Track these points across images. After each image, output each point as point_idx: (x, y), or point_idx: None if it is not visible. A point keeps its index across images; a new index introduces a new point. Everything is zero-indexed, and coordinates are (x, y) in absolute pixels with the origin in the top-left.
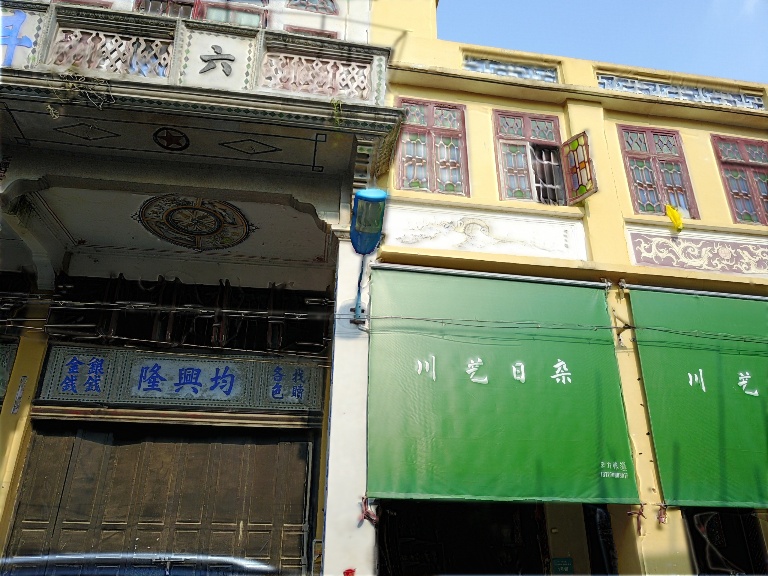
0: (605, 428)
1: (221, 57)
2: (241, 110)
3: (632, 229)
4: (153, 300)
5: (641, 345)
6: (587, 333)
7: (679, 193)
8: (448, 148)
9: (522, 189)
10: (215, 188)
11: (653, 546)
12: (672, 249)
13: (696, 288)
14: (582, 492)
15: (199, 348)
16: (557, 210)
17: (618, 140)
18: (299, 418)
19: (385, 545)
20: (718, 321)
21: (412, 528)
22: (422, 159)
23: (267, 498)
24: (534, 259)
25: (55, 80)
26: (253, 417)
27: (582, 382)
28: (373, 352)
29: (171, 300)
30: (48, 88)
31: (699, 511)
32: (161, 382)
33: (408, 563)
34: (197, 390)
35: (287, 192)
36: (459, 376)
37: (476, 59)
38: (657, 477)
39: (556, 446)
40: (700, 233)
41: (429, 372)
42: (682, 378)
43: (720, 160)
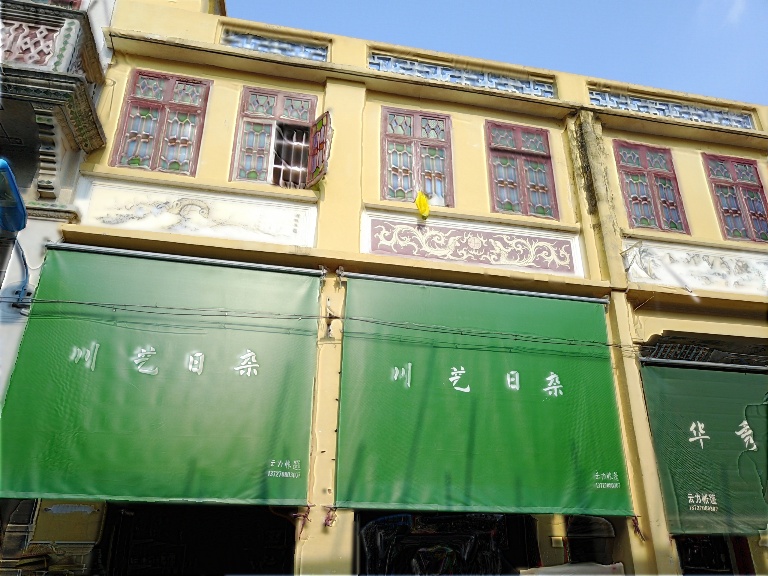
0: (285, 424)
1: None
2: None
3: (374, 215)
4: None
5: (346, 336)
6: (288, 323)
7: (437, 179)
8: (182, 124)
9: (257, 170)
10: None
11: (314, 551)
12: (416, 237)
13: (423, 278)
14: (241, 492)
15: None
16: (289, 193)
17: (380, 123)
18: None
19: (109, 547)
20: (442, 313)
21: (152, 529)
22: (149, 135)
23: None
24: (239, 243)
25: None
26: None
27: (270, 375)
28: (27, 338)
29: None
30: None
31: (377, 513)
32: None
33: (137, 566)
34: None
35: None
36: (125, 366)
37: (238, 33)
38: (335, 477)
39: (223, 443)
40: (450, 221)
41: (88, 361)
42: (387, 372)
43: (489, 147)
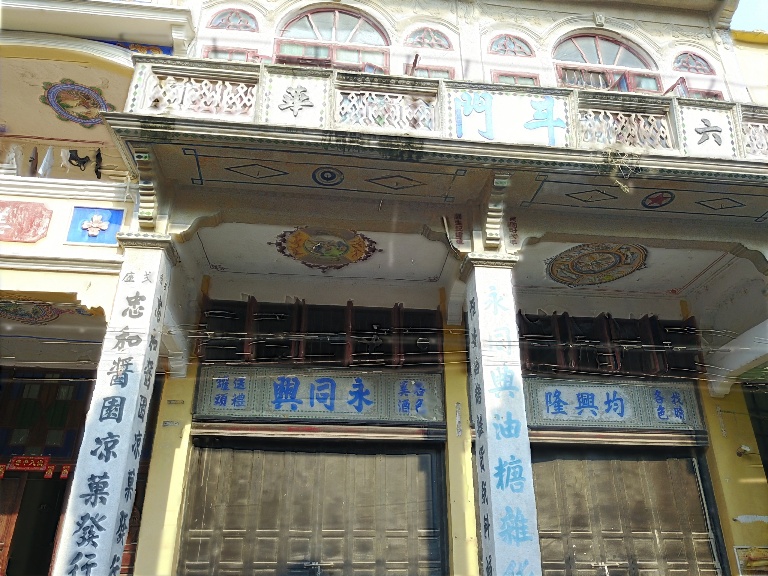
0: None
1: (711, 129)
2: (739, 175)
3: None
4: (547, 332)
5: None
6: None
7: None
8: None
9: None
10: (678, 239)
11: None
12: None
13: None
14: None
15: (586, 375)
16: None
17: None
18: (689, 437)
19: None
20: None
21: None
22: None
23: (670, 509)
24: None
25: (597, 156)
26: (651, 436)
27: None
28: None
29: (567, 332)
30: (591, 163)
31: None
32: (564, 406)
33: None
34: (596, 413)
35: (736, 241)
36: None
37: None
38: None
39: None
40: None
41: None
42: None
43: None
